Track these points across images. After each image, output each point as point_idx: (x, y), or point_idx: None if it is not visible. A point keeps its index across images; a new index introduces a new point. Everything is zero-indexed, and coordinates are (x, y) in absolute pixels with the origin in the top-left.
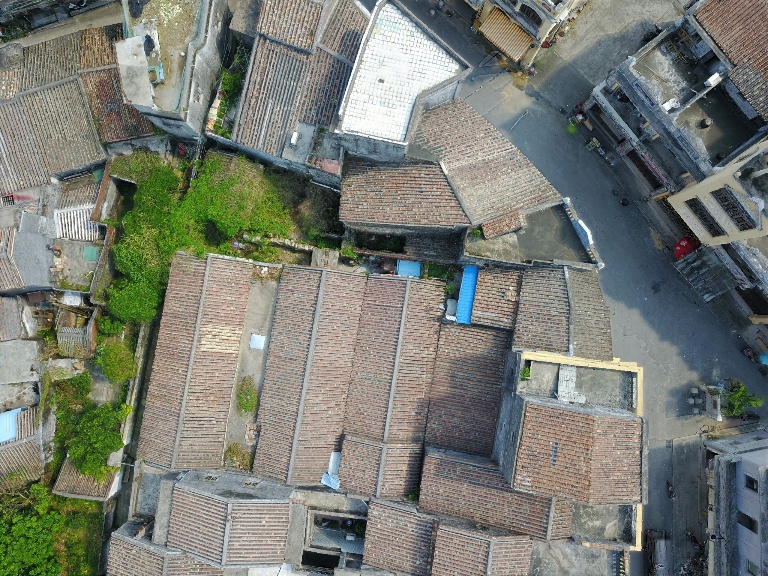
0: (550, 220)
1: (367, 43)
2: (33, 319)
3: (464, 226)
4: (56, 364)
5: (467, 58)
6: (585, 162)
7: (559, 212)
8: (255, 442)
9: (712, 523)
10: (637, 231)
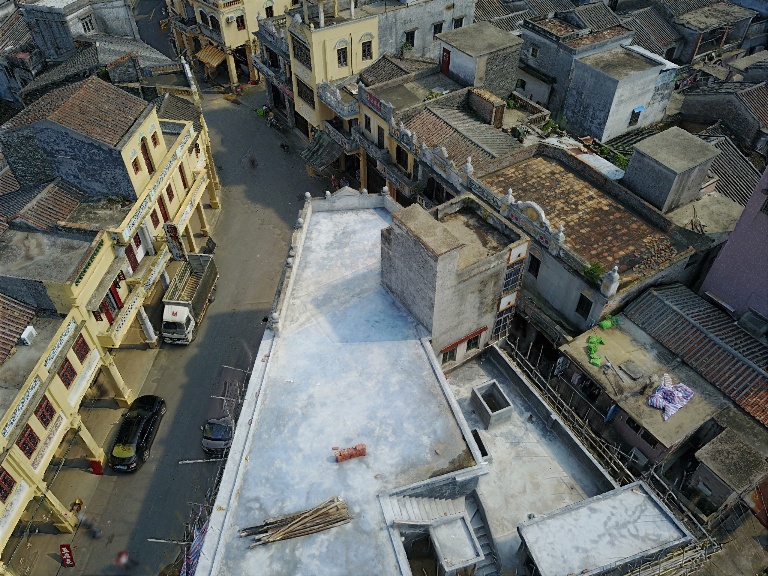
0: (172, 79)
1: None
2: None
3: (95, 68)
4: None
5: None
6: (264, 132)
7: (181, 76)
8: None
9: None
10: (294, 166)
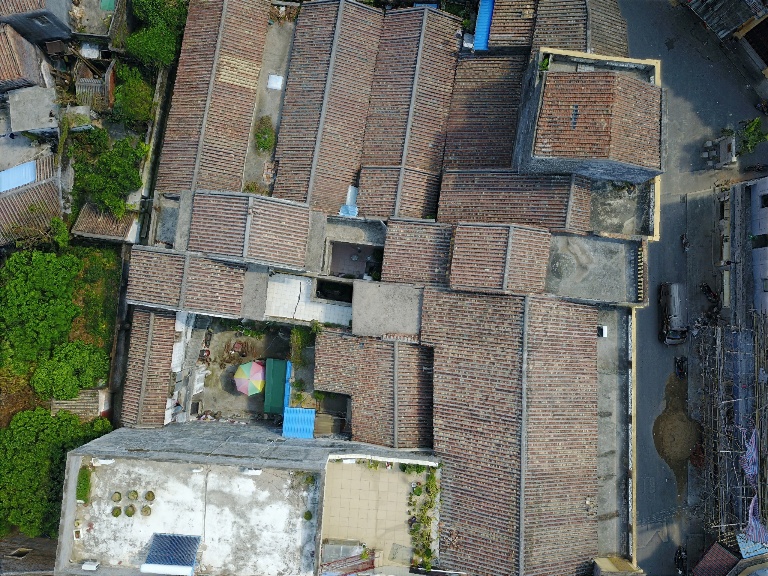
0: None
1: None
2: (51, 77)
3: None
4: (75, 111)
5: None
6: None
7: None
8: (273, 181)
9: (727, 253)
10: None
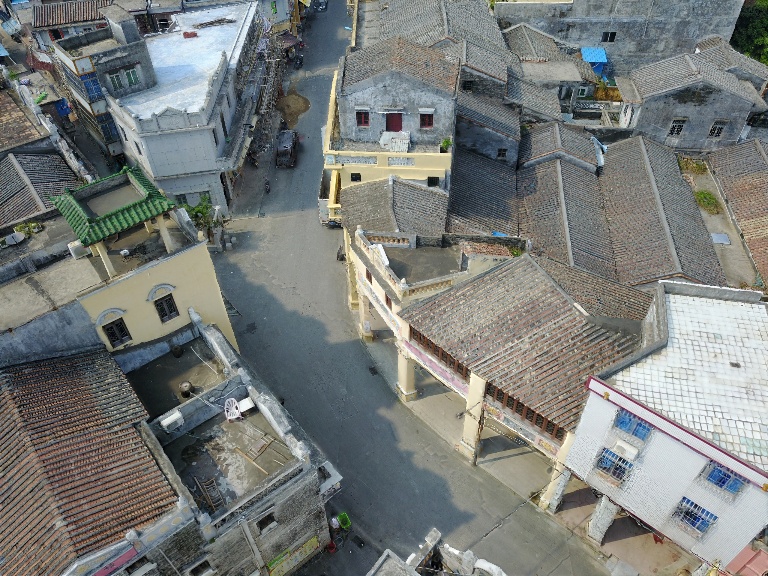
0: None
1: None
2: None
3: None
4: None
5: None
6: None
7: None
8: None
9: (248, 139)
10: None
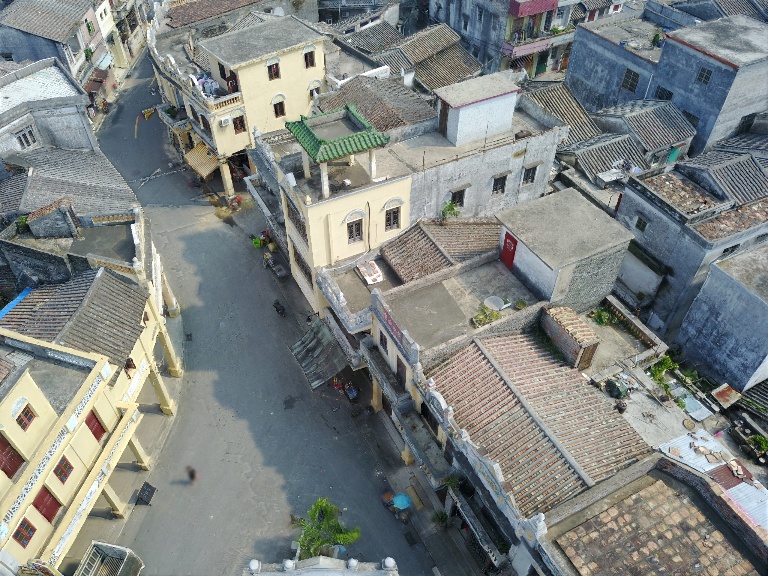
0: (119, 234)
1: (17, 80)
2: None
3: (15, 215)
4: None
5: (183, 194)
6: (256, 276)
7: None
8: None
9: None
10: (288, 342)
